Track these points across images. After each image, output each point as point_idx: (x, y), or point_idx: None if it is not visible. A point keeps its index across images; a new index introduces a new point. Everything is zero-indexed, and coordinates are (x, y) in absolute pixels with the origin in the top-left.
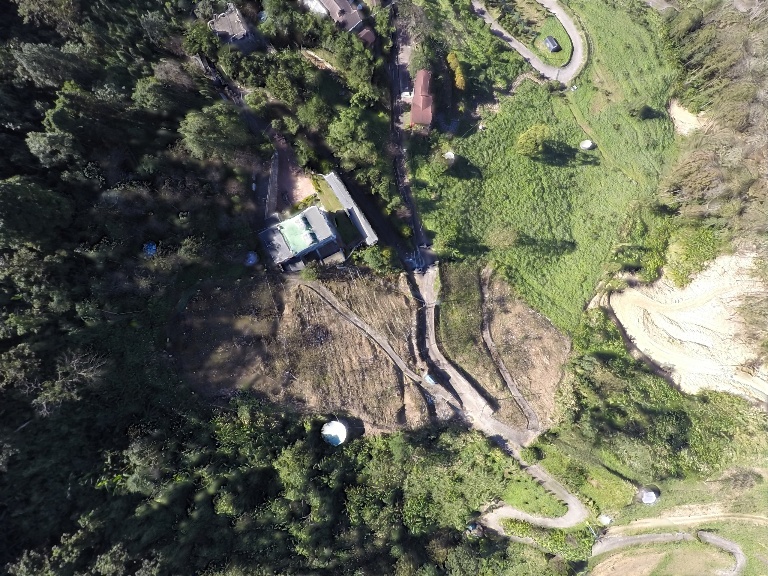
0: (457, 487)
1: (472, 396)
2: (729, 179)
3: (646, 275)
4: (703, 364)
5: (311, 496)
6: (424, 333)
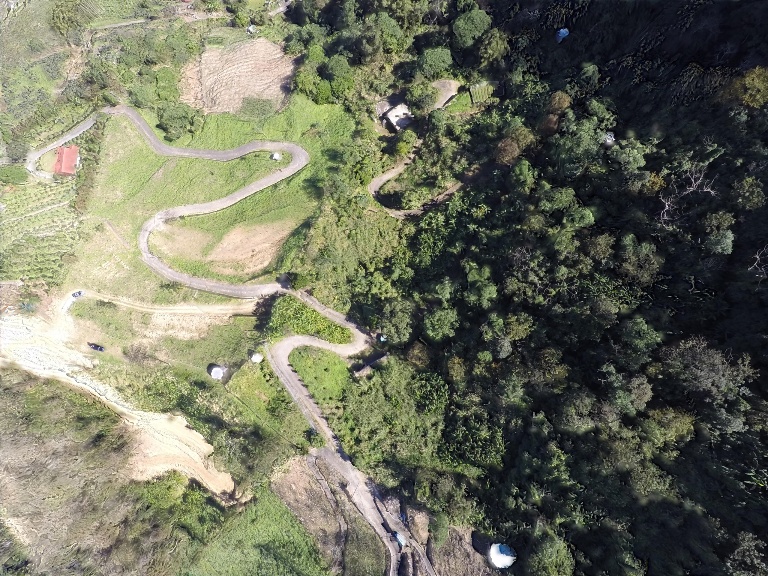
0: (390, 410)
1: (364, 505)
2: (134, 562)
3: (203, 494)
4: (163, 425)
5: (537, 528)
6: (401, 566)
